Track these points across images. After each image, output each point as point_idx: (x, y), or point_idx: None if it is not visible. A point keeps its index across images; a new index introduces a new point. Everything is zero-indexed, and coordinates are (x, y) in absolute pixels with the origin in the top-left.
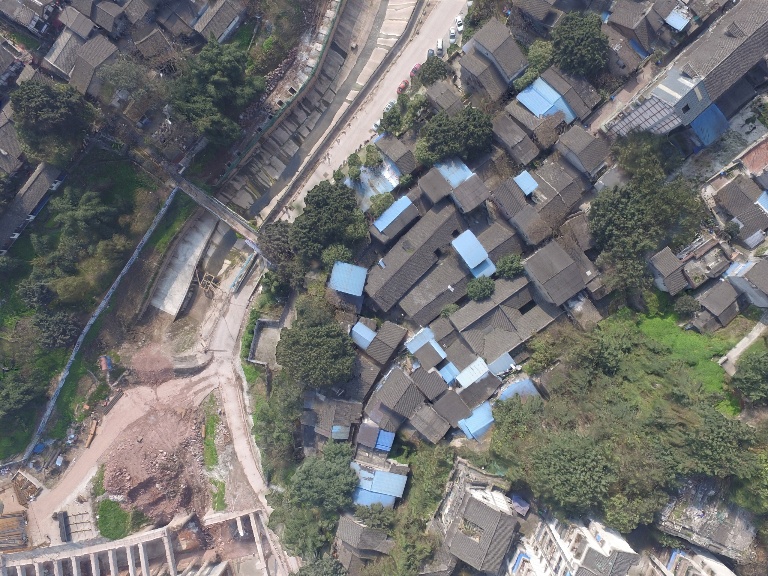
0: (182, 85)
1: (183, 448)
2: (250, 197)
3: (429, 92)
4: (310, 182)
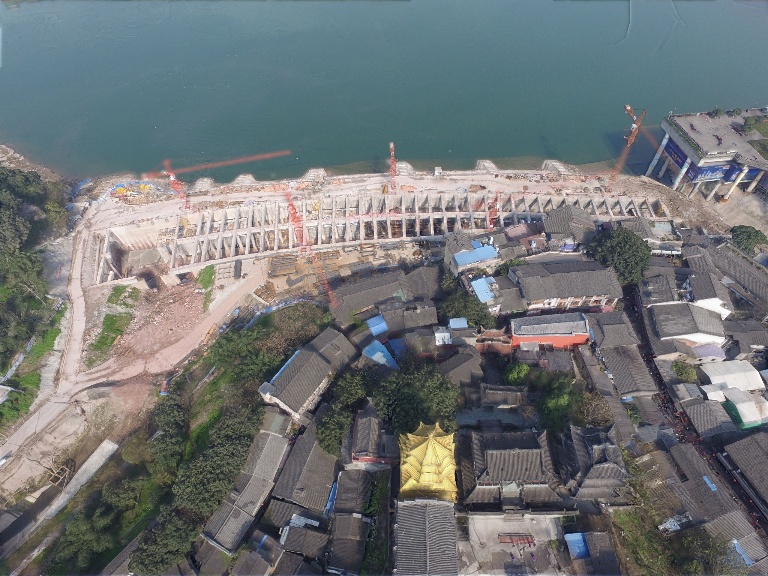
0: None
1: (141, 327)
2: None
3: None
4: None
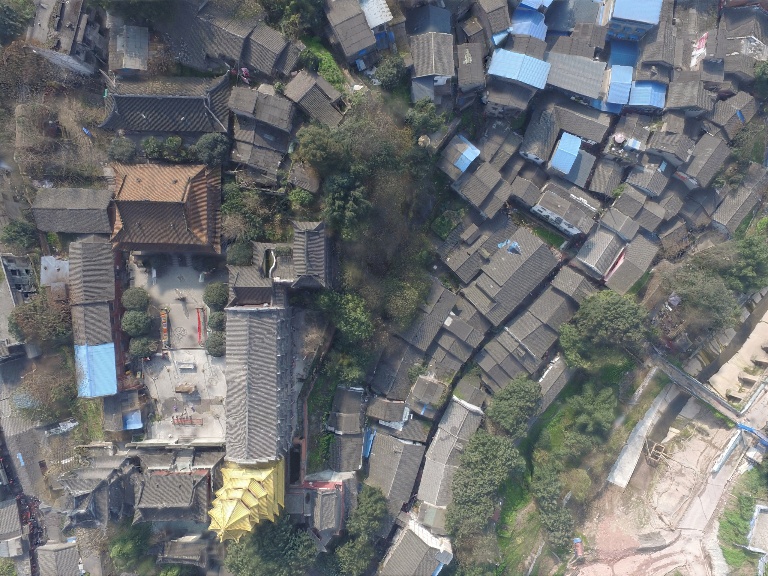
0: None
1: None
2: (699, 364)
3: None
4: None
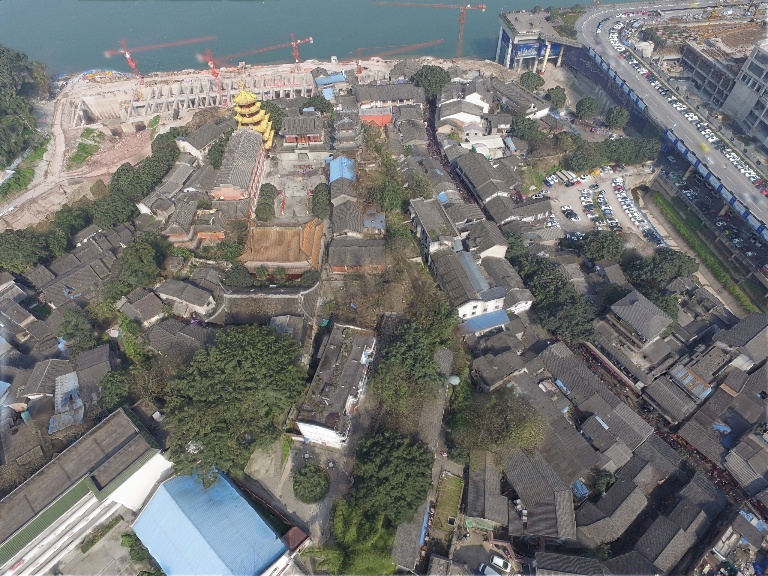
0: None
1: None
2: None
3: None
4: None
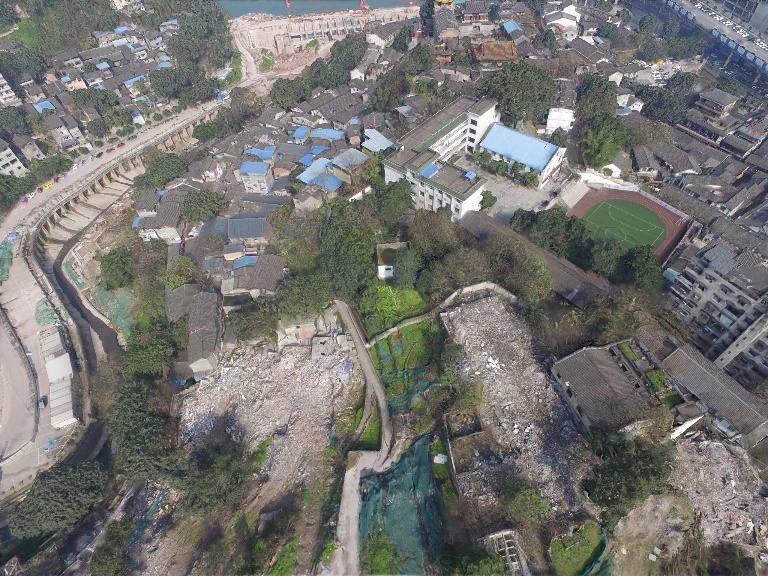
0: (228, 116)
1: None
2: None
3: (99, 117)
4: (187, 118)
